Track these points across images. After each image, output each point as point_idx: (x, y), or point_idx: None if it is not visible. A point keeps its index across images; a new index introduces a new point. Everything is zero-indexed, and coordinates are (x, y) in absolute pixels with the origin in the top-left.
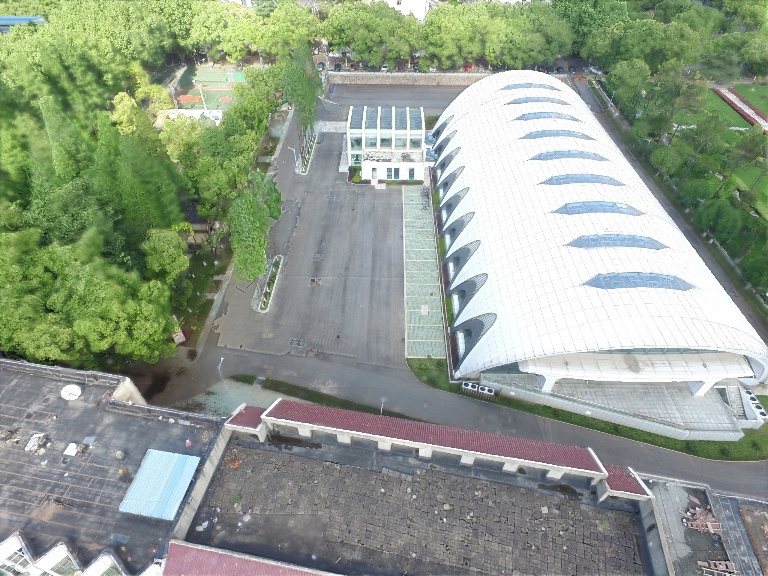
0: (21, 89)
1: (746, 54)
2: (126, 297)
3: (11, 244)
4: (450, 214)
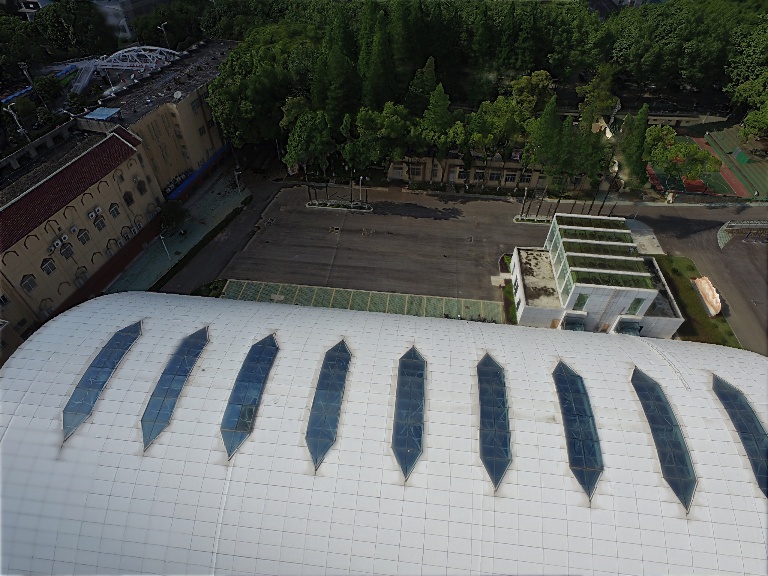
0: (471, 24)
1: None
2: (240, 98)
3: (277, 55)
4: None
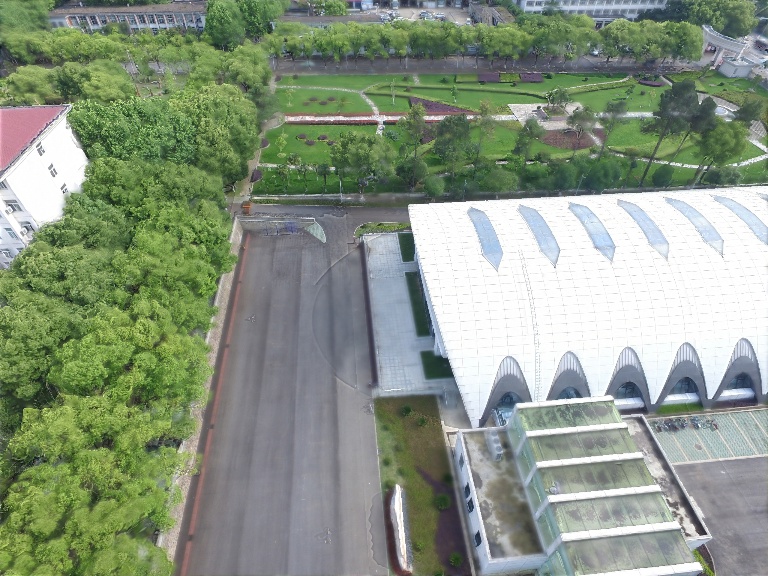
0: None
1: (248, 81)
2: None
3: None
4: (759, 377)
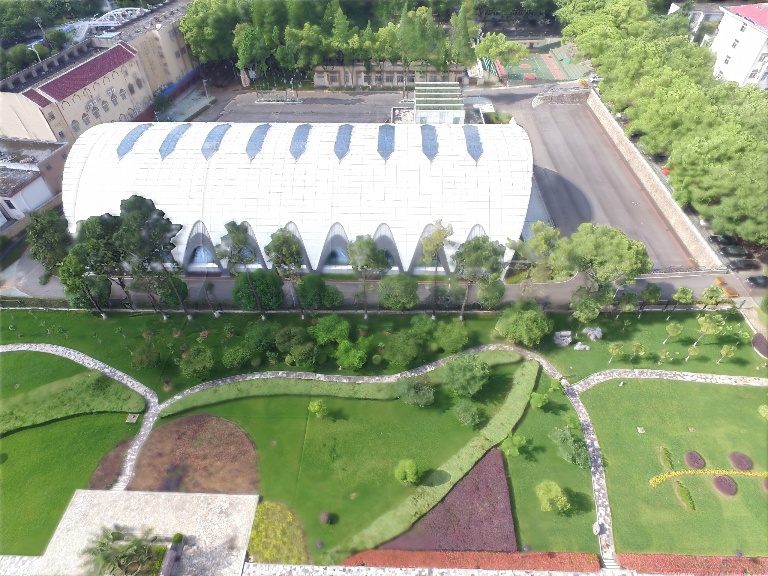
0: None
1: None
2: (203, 26)
3: None
4: None
